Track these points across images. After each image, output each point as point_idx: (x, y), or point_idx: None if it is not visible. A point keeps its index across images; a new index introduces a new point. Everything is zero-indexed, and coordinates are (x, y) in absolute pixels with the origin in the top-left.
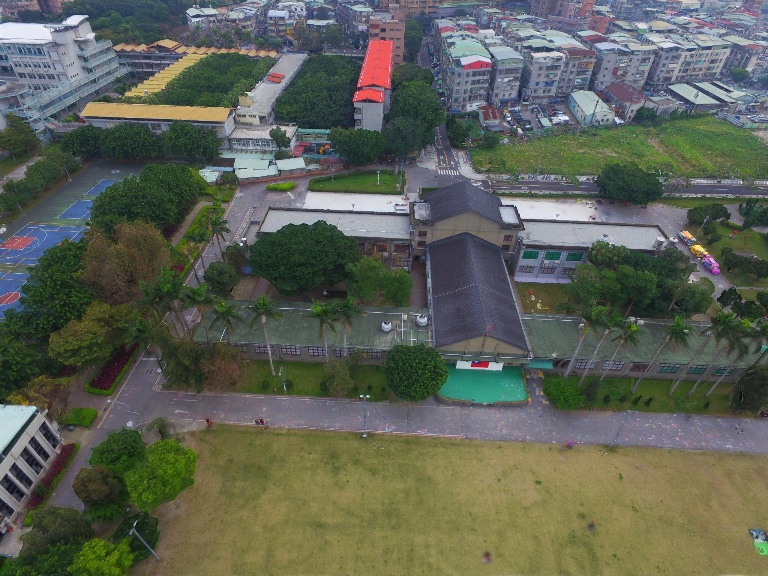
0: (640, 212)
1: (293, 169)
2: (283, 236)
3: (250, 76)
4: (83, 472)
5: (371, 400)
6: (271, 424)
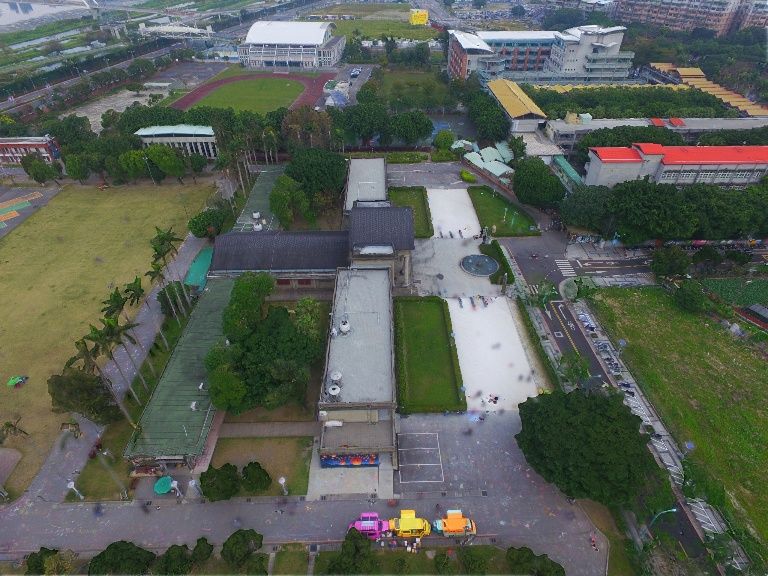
0: (547, 484)
1: (491, 172)
2: (319, 152)
3: (661, 114)
4: (174, 146)
5: None
6: None
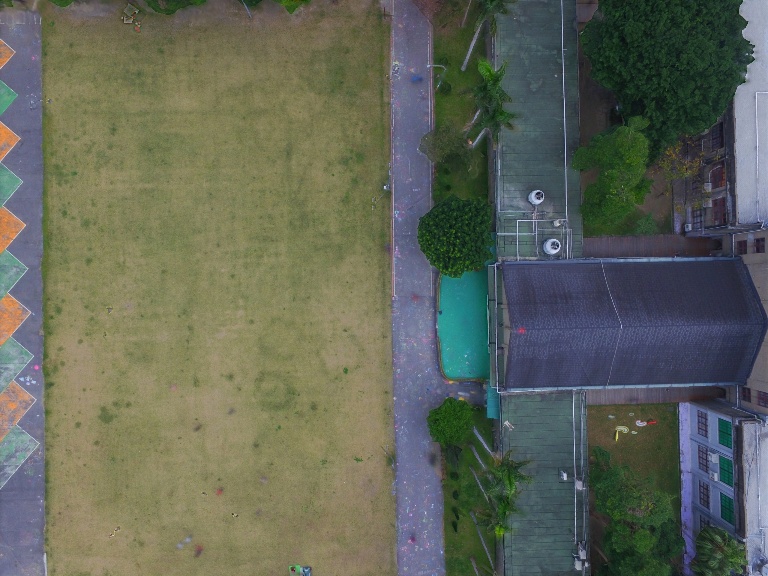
0: None
1: None
2: None
3: None
4: None
5: (434, 191)
6: (394, 82)
